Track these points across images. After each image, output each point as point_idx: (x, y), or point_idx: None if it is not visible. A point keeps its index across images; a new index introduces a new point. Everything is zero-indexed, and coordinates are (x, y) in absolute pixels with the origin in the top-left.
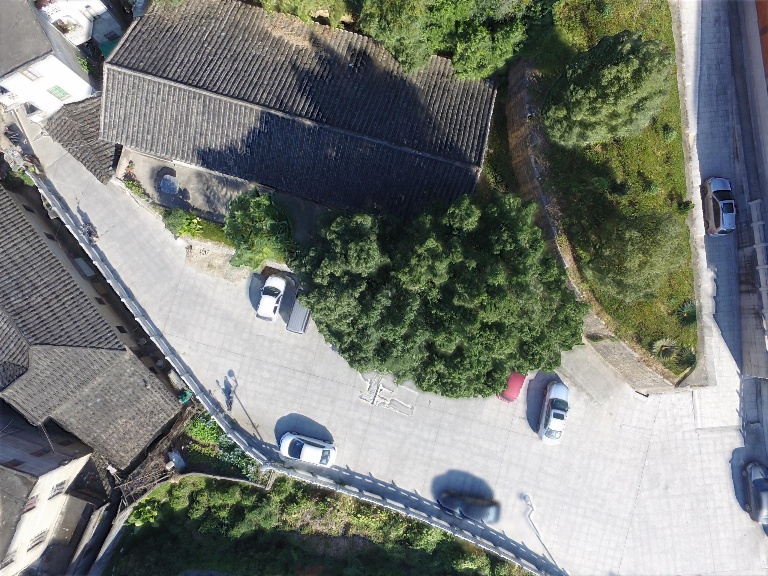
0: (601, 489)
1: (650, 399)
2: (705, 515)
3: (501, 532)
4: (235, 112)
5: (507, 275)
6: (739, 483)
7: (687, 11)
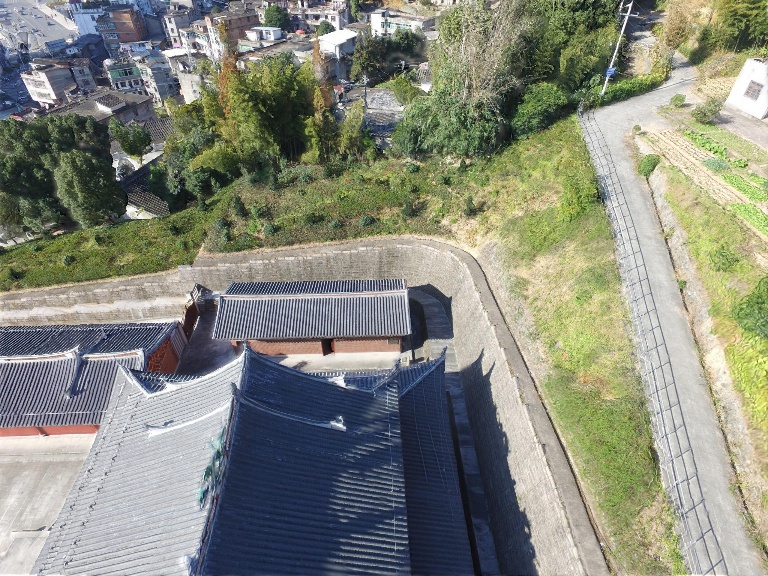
0: None
1: None
2: None
3: None
4: None
5: (15, 132)
6: None
7: None
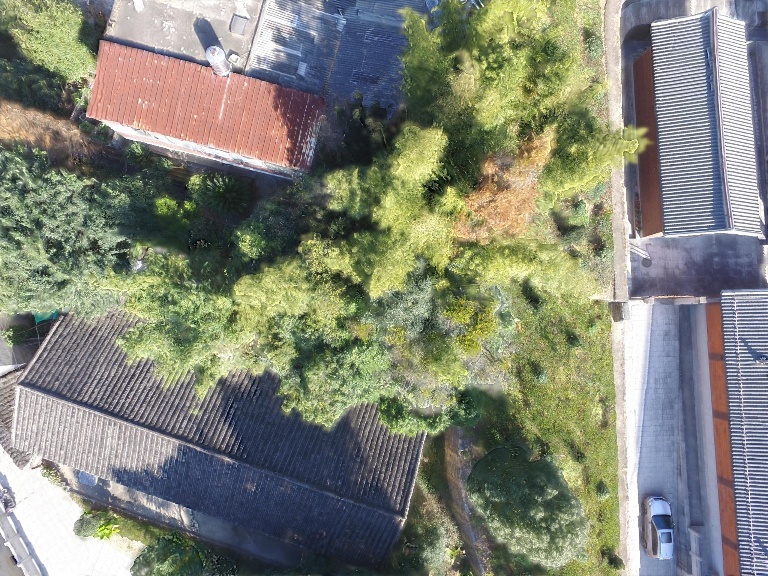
0: None
1: None
2: None
3: None
4: (152, 441)
5: None
6: None
7: (637, 323)
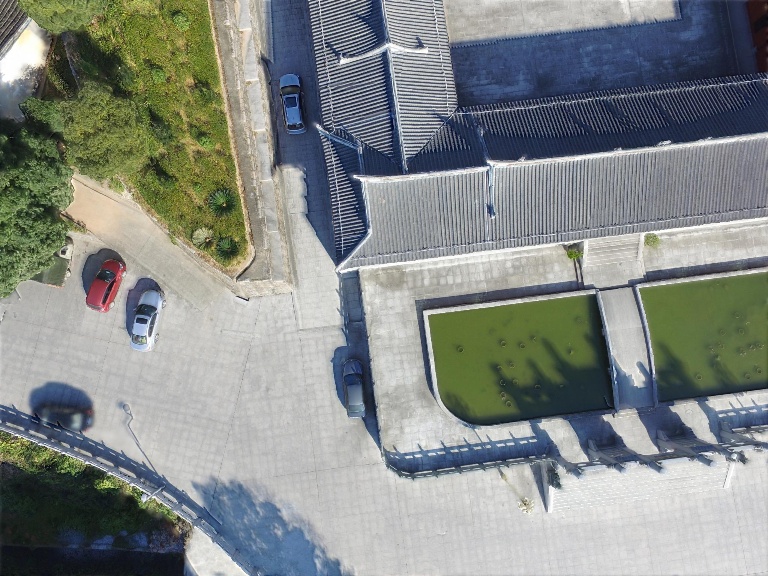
0: (201, 394)
1: (250, 303)
2: (306, 415)
3: (100, 442)
4: None
5: None
6: (340, 381)
7: None
